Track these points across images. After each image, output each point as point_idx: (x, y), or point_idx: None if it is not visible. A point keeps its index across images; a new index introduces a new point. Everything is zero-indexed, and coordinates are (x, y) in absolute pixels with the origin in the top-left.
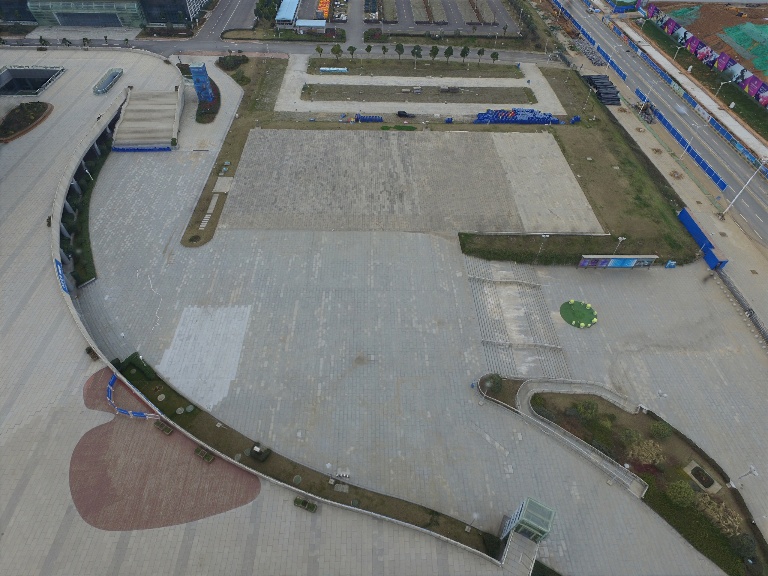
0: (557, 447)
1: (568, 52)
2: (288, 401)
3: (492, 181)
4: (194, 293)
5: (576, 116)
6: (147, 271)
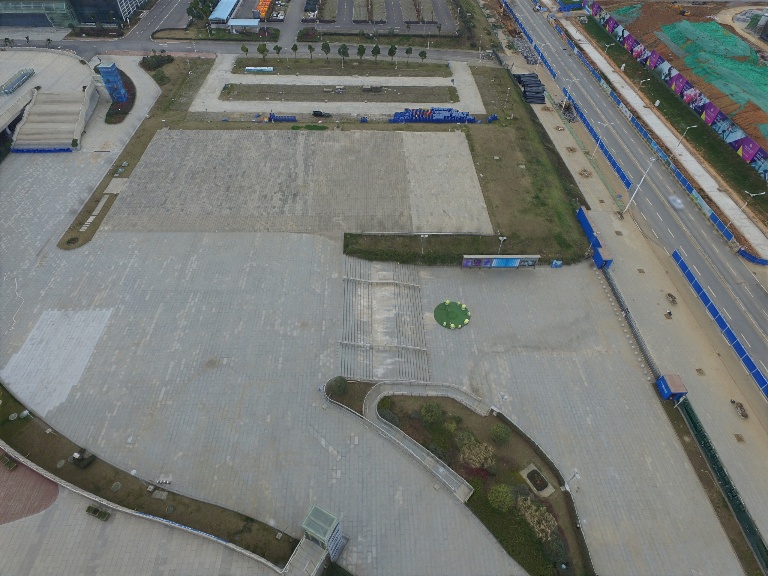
0: (392, 451)
1: (504, 51)
2: (127, 406)
3: (391, 181)
4: (58, 296)
5: (493, 115)
6: (15, 274)
